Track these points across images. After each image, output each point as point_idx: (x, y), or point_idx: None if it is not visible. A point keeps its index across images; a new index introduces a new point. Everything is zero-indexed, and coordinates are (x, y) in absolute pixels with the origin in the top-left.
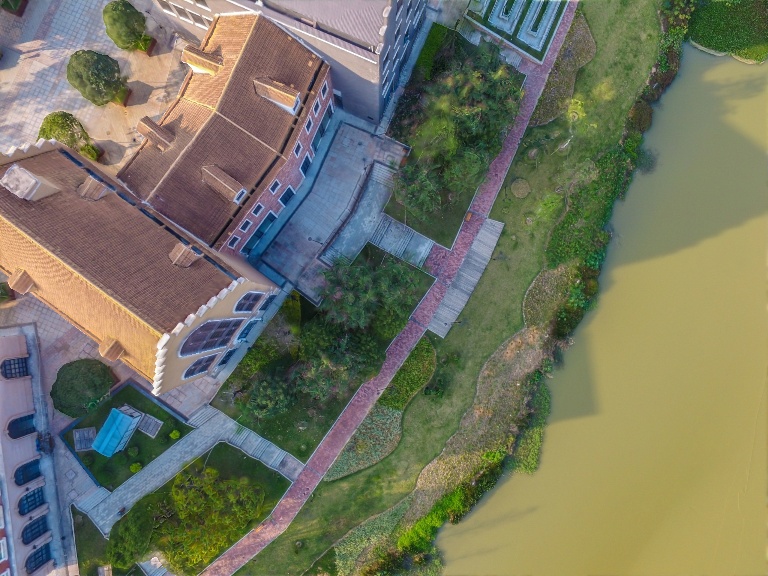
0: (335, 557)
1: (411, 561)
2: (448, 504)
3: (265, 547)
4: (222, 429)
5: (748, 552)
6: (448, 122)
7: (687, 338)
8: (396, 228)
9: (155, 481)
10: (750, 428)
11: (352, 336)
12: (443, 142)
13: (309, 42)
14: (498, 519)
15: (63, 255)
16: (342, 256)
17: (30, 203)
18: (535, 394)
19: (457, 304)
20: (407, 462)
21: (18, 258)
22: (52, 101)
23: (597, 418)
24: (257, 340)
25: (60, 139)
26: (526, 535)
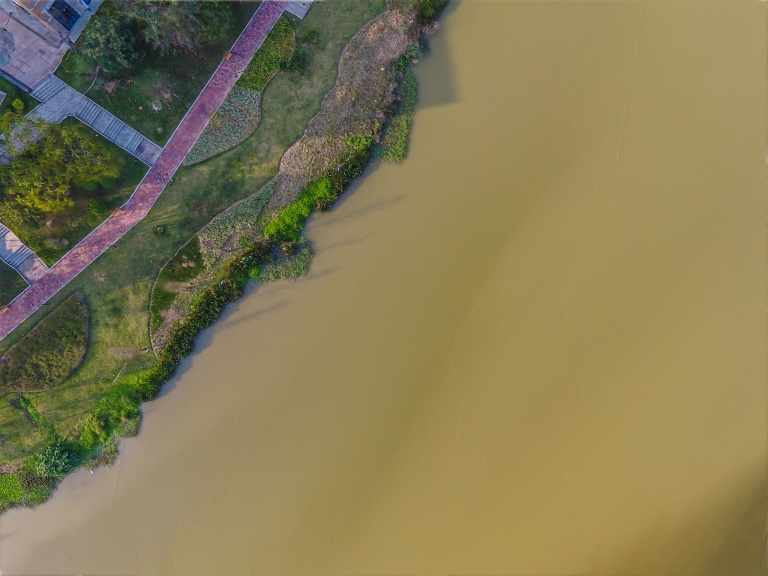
0: (199, 245)
1: (279, 251)
2: (314, 191)
3: (125, 233)
4: (70, 104)
5: (619, 232)
6: None
7: (556, 22)
8: None
9: None
10: (621, 111)
11: None
12: None
13: None
14: (367, 208)
15: None
16: None
17: None
18: (401, 82)
19: None
20: (268, 144)
21: None
22: None
23: (465, 105)
24: (100, 7)
25: None
26: (395, 222)
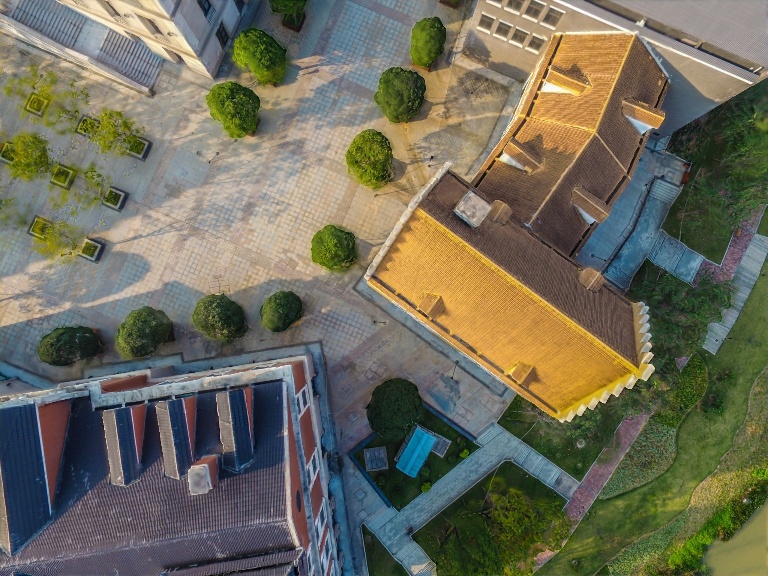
0: (608, 575)
1: None
2: (718, 521)
3: (542, 566)
4: (506, 448)
5: None
6: (766, 140)
7: None
8: (670, 244)
9: (441, 500)
10: None
11: (655, 355)
12: (761, 160)
13: (670, 62)
14: (766, 536)
15: (527, 284)
16: (621, 273)
17: (473, 230)
18: None
19: (727, 320)
20: (682, 480)
21: (444, 285)
22: (332, 117)
23: None
24: None
25: (377, 158)
26: None
